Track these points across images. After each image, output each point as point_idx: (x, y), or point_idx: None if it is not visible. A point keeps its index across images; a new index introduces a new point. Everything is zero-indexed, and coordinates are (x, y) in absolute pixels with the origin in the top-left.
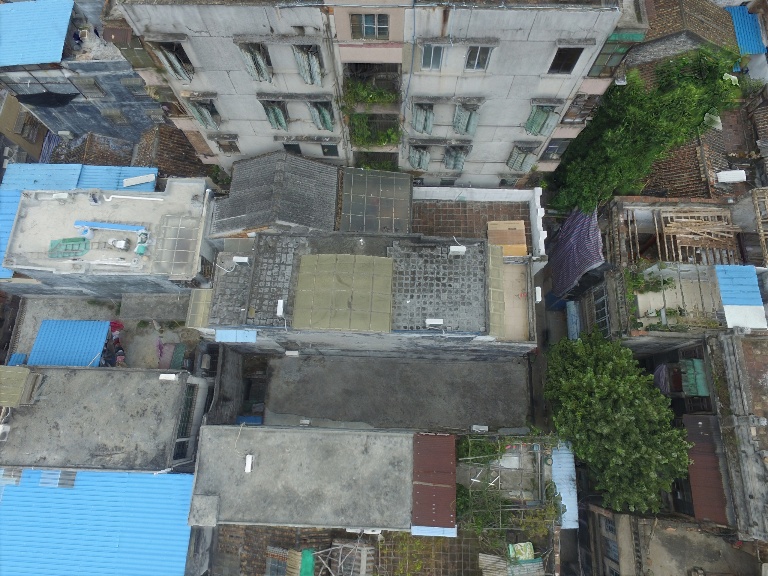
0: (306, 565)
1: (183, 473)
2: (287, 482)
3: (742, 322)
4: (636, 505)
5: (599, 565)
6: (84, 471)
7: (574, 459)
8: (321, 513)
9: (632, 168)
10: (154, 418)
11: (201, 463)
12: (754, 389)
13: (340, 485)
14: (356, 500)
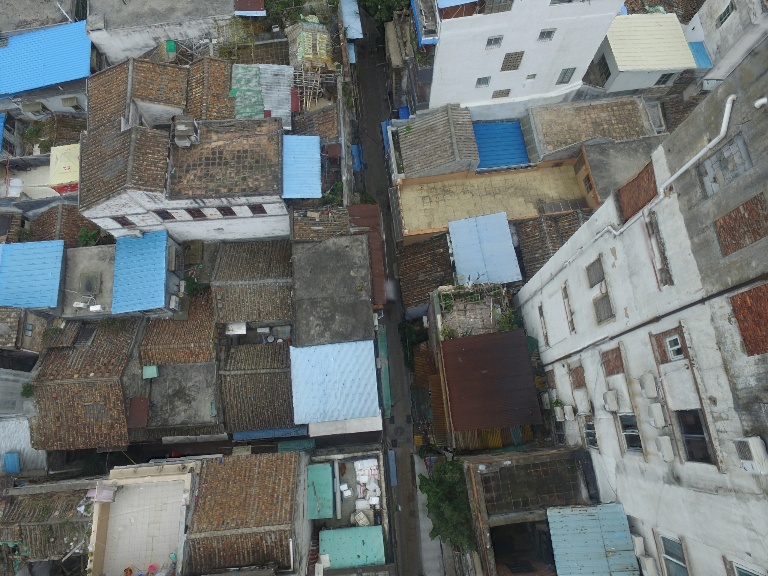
0: (170, 46)
1: (81, 20)
2: (151, 6)
3: None
4: (390, 2)
5: (392, 82)
6: (13, 37)
7: (357, 3)
8: (175, 16)
9: None
10: (57, 1)
11: (91, 6)
12: None
13: (186, 2)
14: (198, 7)
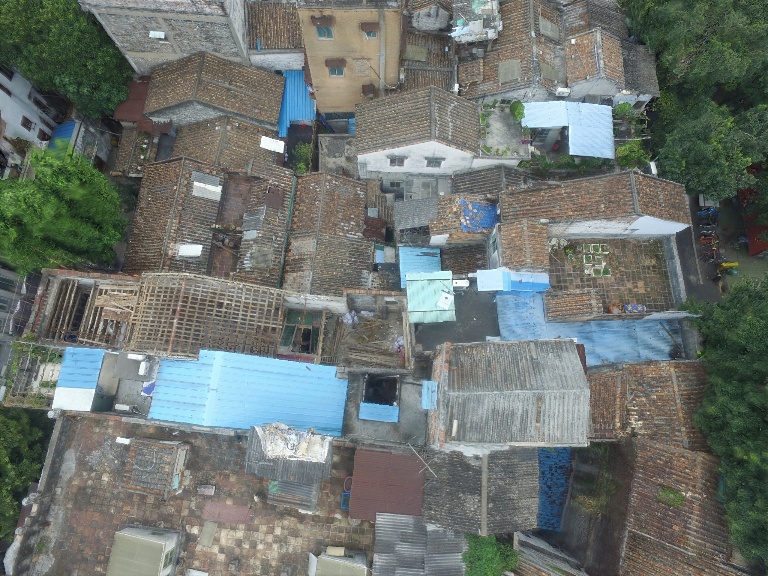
0: None
1: None
2: None
3: (67, 404)
4: None
5: None
6: None
7: None
8: None
9: (11, 249)
10: None
11: None
12: (79, 465)
13: None
14: None
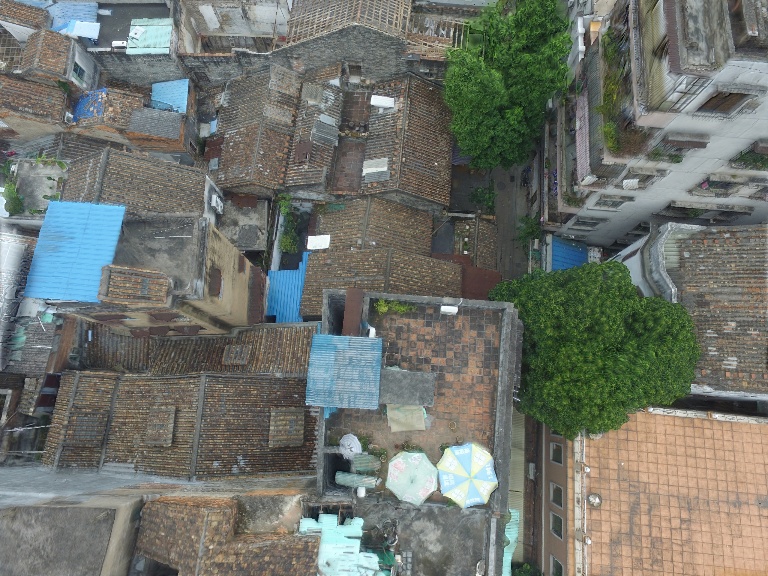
0: None
1: None
2: None
3: None
4: None
5: None
6: None
7: None
8: None
9: None
10: None
11: None
12: None
13: None
14: None
